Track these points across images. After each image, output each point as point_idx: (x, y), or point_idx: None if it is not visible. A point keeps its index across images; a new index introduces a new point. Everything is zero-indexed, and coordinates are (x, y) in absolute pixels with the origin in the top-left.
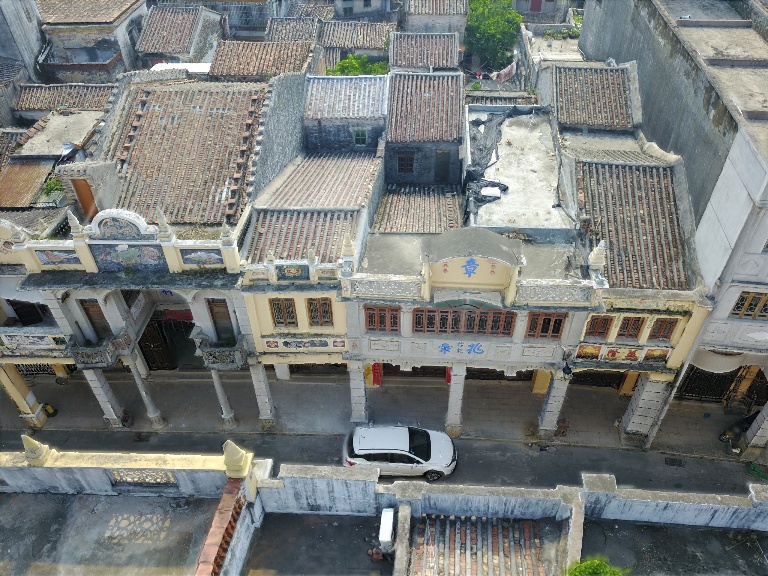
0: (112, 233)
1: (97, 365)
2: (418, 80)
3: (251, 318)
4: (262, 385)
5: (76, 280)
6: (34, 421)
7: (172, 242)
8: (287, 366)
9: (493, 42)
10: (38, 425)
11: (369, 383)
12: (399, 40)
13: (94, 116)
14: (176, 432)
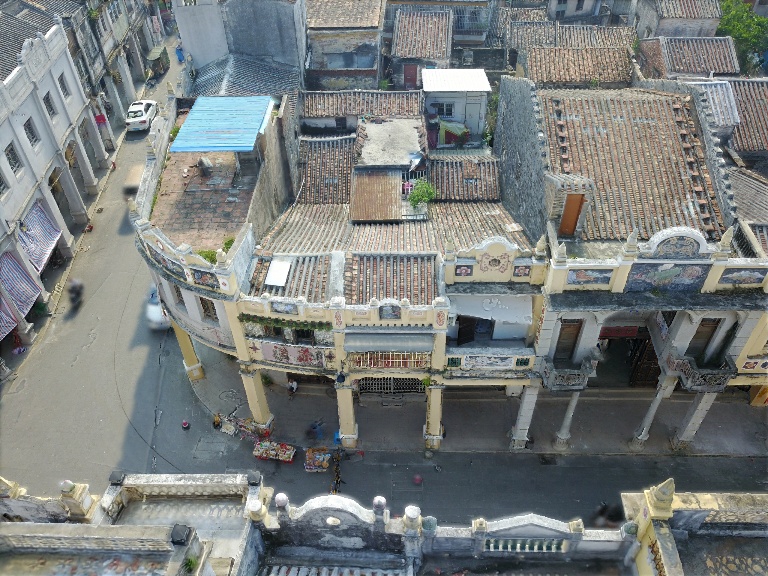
0: (667, 252)
1: (573, 387)
2: (745, 86)
3: (751, 339)
4: (707, 406)
5: (607, 301)
6: (433, 443)
7: (728, 261)
8: (675, 384)
9: (747, 46)
10: (435, 447)
11: (760, 401)
12: (671, 45)
13: (409, 124)
14: (581, 454)
